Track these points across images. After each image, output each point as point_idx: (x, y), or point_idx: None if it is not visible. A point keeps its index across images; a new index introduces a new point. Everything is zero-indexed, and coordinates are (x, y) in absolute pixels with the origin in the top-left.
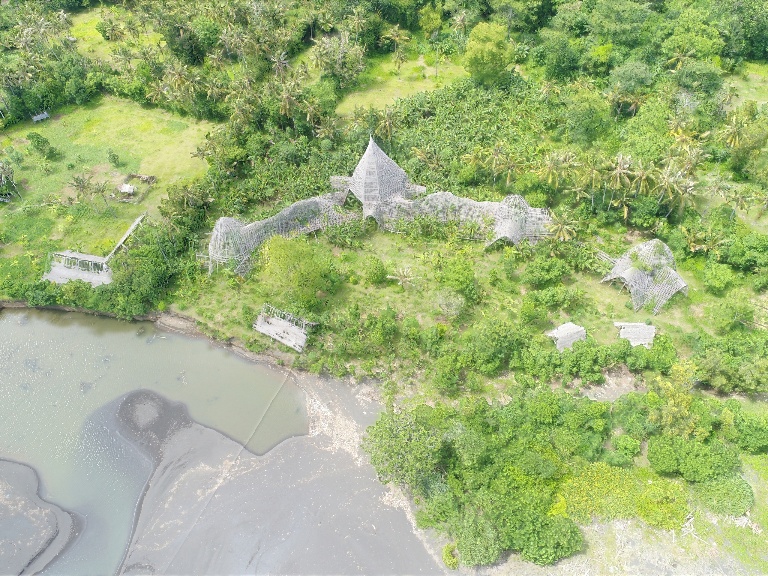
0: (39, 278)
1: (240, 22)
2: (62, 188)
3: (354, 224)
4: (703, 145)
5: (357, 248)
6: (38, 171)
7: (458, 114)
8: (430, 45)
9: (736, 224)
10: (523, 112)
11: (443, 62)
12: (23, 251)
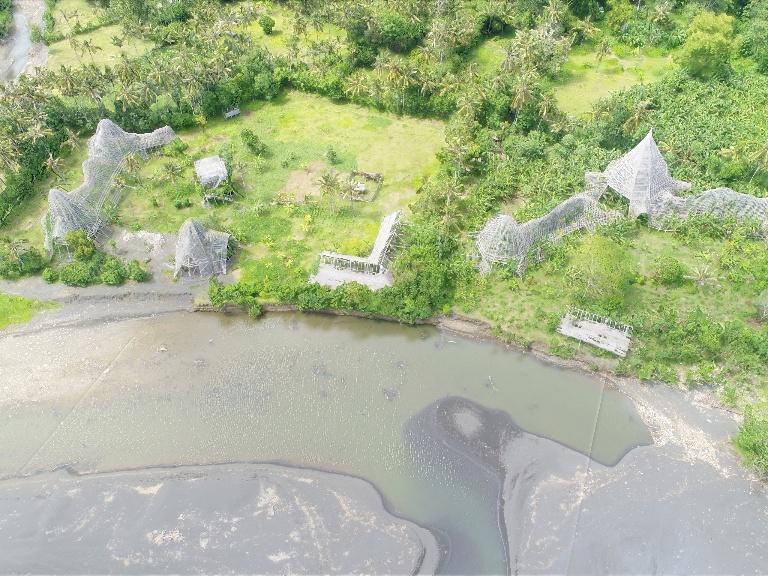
0: None
1: (421, 14)
2: (284, 186)
3: (625, 222)
4: None
5: (628, 247)
6: (251, 169)
7: (688, 107)
8: (619, 37)
9: None
10: (752, 105)
11: (637, 54)
12: (269, 252)
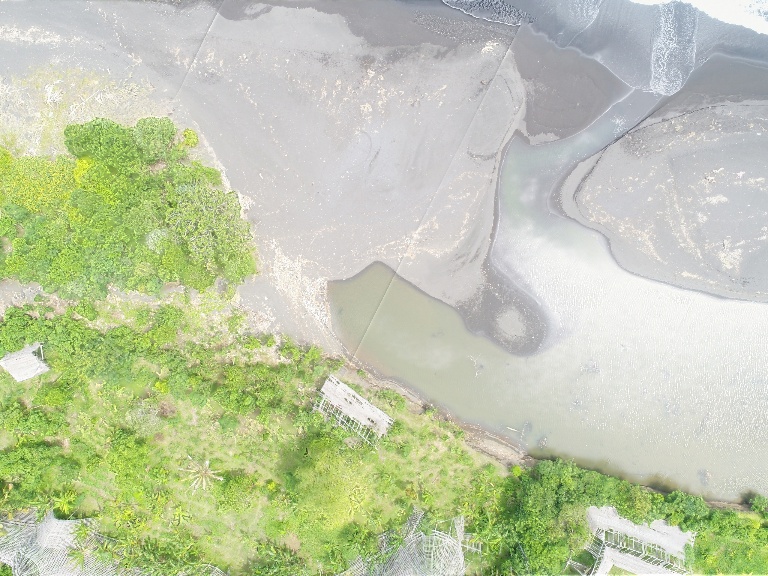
0: (702, 543)
1: None
2: None
3: None
4: None
5: None
6: None
7: None
8: None
9: None
10: None
11: None
12: None
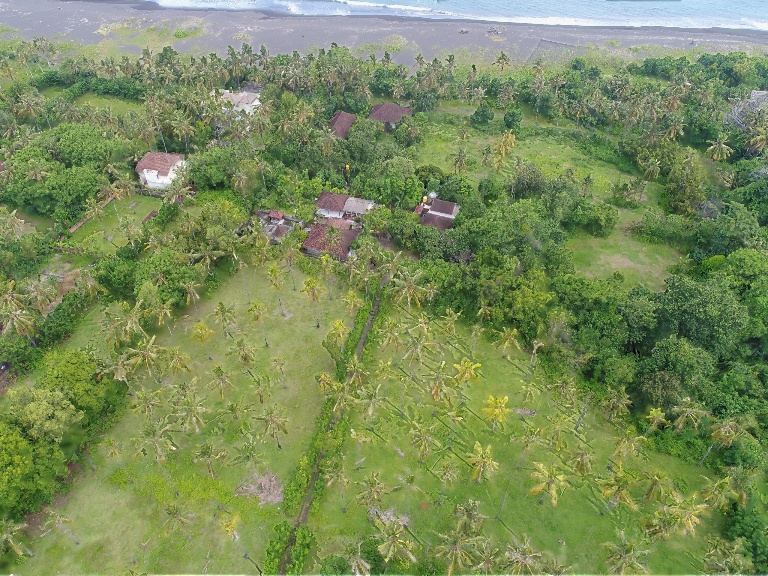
0: None
1: None
2: None
3: None
4: (715, 201)
5: None
6: None
7: None
8: None
9: (705, 124)
10: None
11: None
12: None
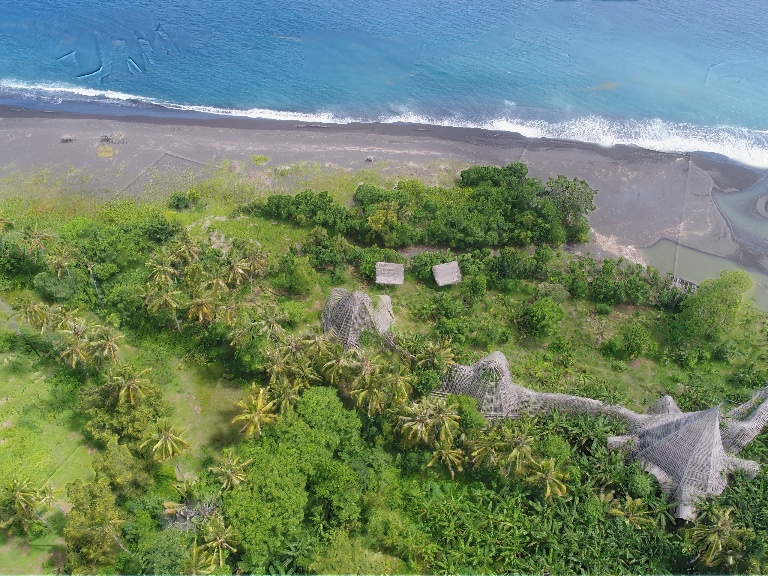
0: None
1: None
2: None
3: None
4: None
5: (667, 394)
6: None
7: None
8: None
9: None
10: None
11: None
12: None
